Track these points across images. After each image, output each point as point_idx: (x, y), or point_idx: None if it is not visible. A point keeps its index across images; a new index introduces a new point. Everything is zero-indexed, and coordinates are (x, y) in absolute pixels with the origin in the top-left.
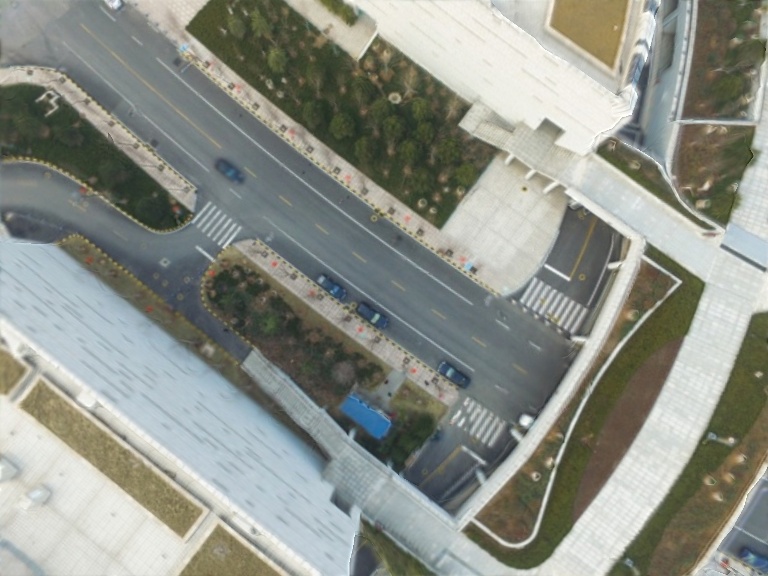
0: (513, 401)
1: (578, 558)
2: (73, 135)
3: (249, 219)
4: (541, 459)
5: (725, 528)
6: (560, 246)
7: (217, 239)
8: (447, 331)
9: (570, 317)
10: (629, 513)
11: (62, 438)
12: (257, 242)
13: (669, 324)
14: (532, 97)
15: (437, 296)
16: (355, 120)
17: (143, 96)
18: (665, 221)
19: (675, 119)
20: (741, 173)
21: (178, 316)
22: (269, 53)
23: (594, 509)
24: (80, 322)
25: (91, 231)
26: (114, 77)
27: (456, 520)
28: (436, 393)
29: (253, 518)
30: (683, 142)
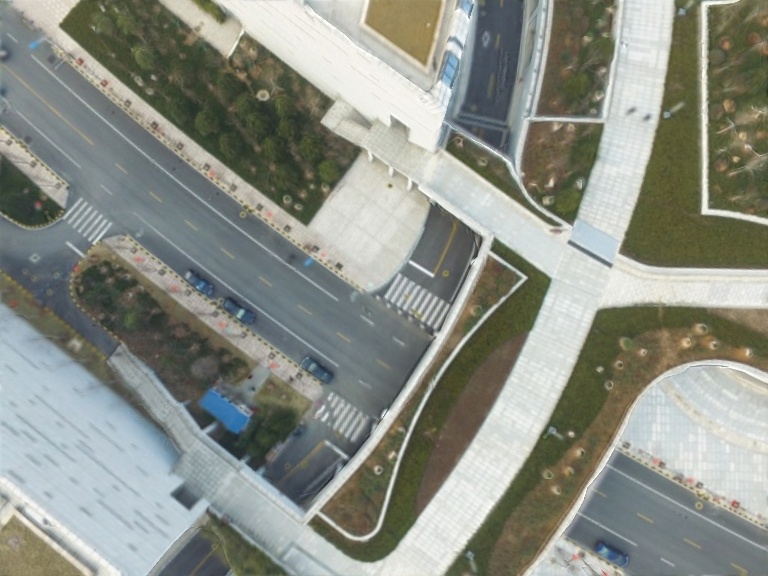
0: (376, 396)
1: (422, 551)
2: None
3: (120, 215)
4: (384, 453)
5: (565, 521)
6: (425, 242)
7: (87, 235)
8: (313, 327)
9: (433, 313)
10: (471, 506)
11: None
12: (127, 238)
13: (513, 319)
14: (371, 94)
15: (303, 292)
16: (219, 117)
17: (17, 93)
18: (514, 217)
19: (529, 116)
20: (589, 170)
21: (47, 311)
22: (137, 50)
23: (437, 502)
24: None
25: None
26: None
27: (303, 513)
28: (300, 388)
29: (44, 509)
30: (531, 139)
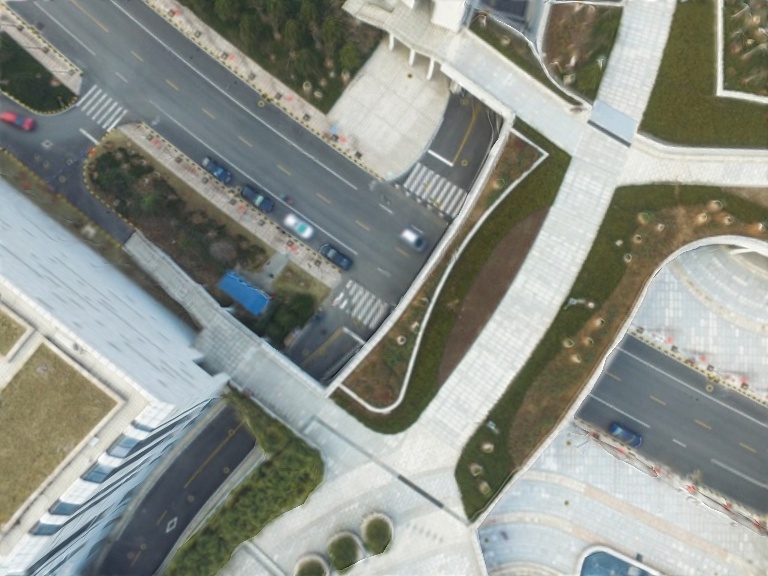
0: (395, 283)
1: (443, 423)
2: None
3: (135, 103)
4: (407, 324)
5: (584, 391)
6: (444, 132)
7: (102, 122)
8: (331, 215)
9: (452, 202)
10: (493, 377)
11: None
12: (142, 125)
13: (535, 194)
14: None
15: (322, 180)
16: (239, 1)
17: None
18: (535, 97)
19: None
20: (609, 52)
21: (60, 198)
22: None
23: (459, 374)
24: None
25: None
26: None
27: (324, 387)
28: (318, 275)
29: (75, 333)
30: (553, 20)
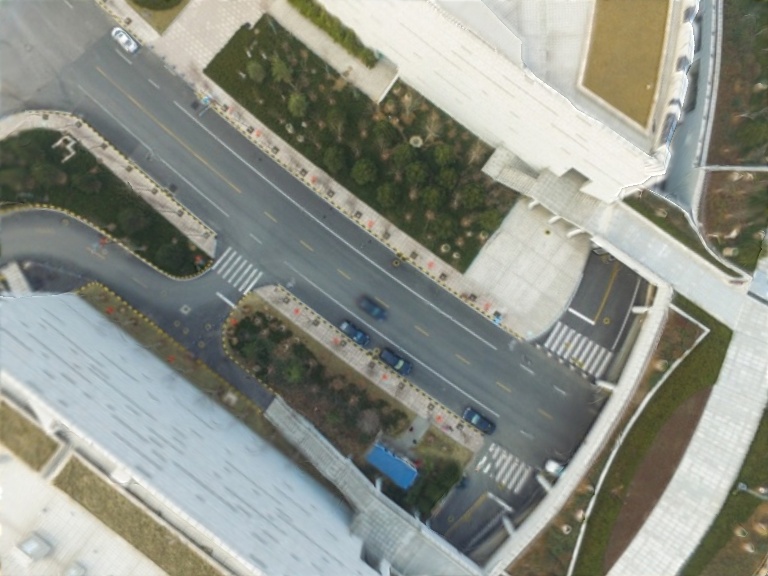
0: (539, 446)
1: None
2: (91, 182)
3: (270, 264)
4: (571, 511)
5: None
6: (584, 290)
7: (238, 285)
8: (471, 376)
9: (595, 361)
10: (660, 564)
11: (96, 515)
12: (278, 288)
13: (698, 373)
14: (560, 149)
15: (461, 341)
16: (377, 165)
17: (161, 140)
18: (692, 269)
19: (700, 164)
20: (767, 220)
21: (199, 364)
22: (289, 98)
23: (625, 561)
24: (107, 384)
25: (110, 279)
26: (131, 121)
27: (486, 573)
28: (461, 439)
29: None
30: (709, 189)
